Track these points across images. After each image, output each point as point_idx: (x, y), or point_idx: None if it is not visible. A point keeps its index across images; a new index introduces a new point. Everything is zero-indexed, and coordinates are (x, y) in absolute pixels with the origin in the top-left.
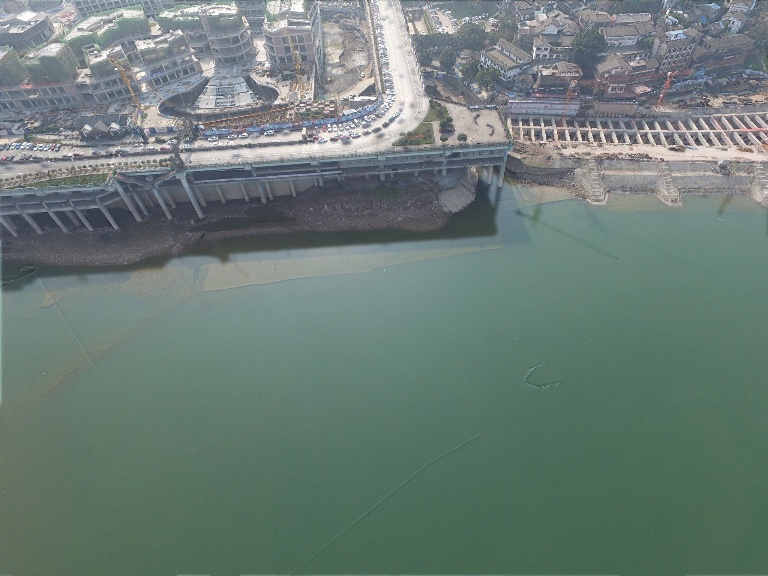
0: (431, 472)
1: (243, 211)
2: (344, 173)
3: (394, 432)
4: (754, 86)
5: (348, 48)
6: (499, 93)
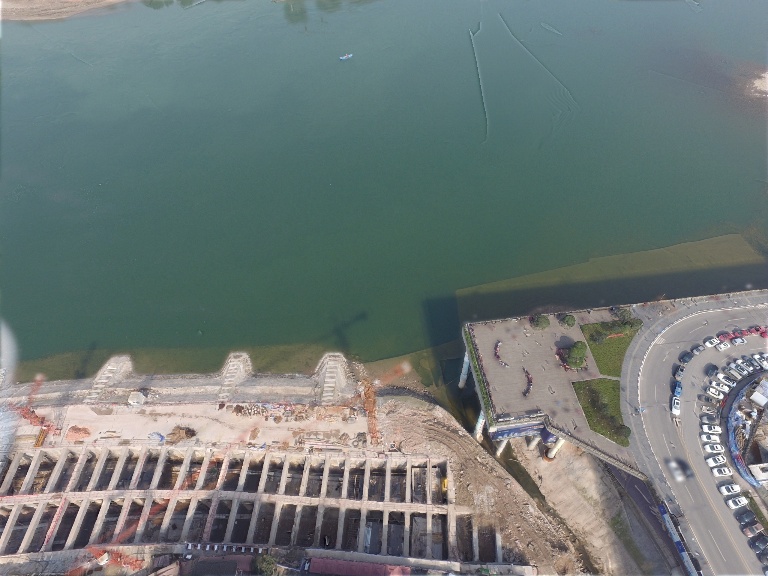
0: None
1: None
2: None
3: (526, 122)
4: None
5: None
6: None
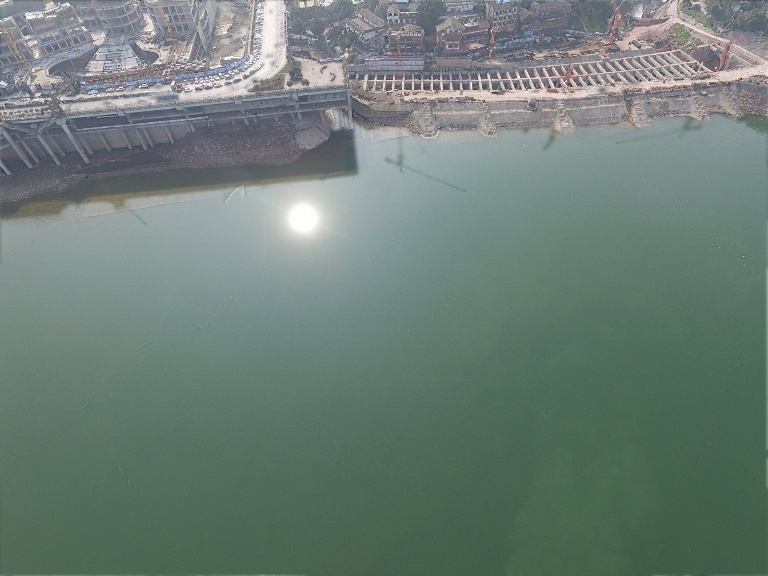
0: (251, 329)
1: (126, 156)
2: (210, 118)
3: (210, 291)
4: (573, 43)
5: (237, 22)
6: (359, 54)
